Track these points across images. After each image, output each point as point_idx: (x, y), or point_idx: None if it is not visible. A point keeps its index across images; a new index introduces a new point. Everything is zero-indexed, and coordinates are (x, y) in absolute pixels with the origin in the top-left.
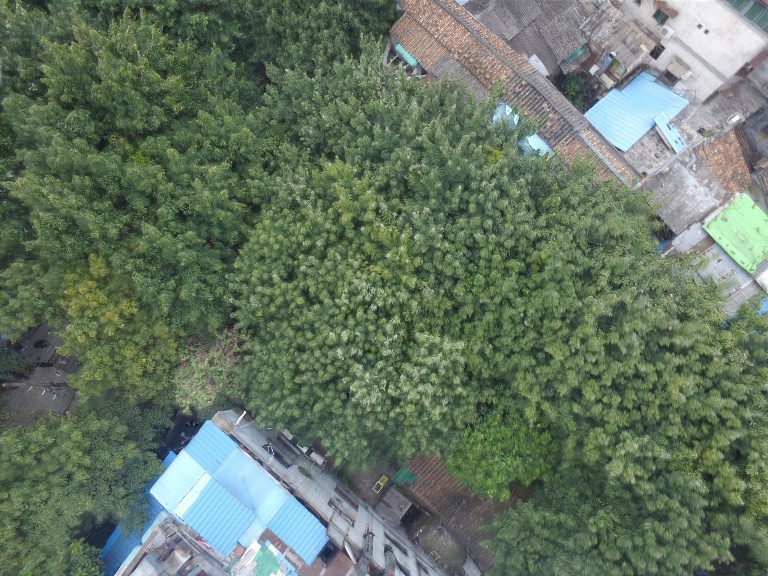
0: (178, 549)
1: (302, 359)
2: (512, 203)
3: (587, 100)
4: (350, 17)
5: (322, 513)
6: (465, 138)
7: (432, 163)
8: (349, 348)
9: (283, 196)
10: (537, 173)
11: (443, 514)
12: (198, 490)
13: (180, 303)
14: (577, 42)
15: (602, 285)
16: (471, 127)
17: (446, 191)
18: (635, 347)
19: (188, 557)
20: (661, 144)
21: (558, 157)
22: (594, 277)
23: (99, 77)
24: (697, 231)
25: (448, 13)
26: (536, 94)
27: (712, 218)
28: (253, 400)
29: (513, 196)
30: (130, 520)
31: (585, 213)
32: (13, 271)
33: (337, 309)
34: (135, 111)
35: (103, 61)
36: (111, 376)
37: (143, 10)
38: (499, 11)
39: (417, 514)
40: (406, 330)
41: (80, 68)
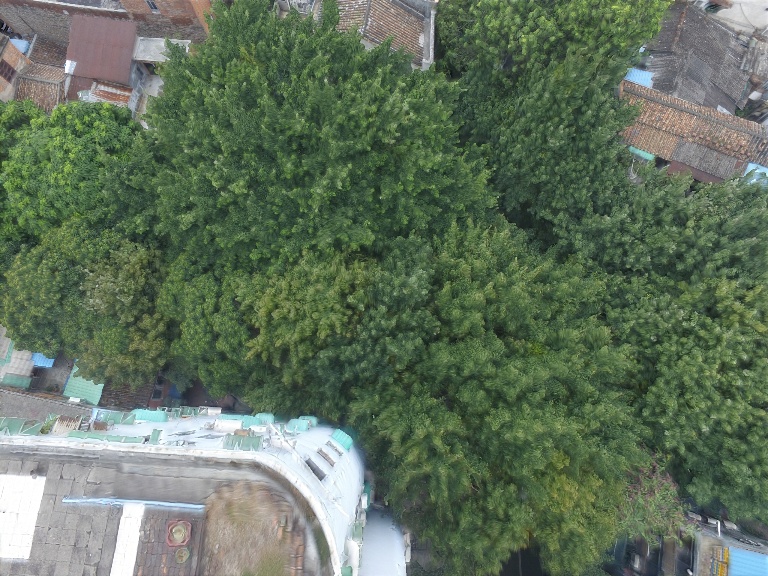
0: None
1: None
2: None
3: None
4: None
5: None
6: None
7: None
8: None
9: None
10: None
11: None
12: None
13: None
14: (743, 81)
15: None
16: None
17: None
18: None
19: None
20: None
21: None
22: None
23: None
24: None
25: (669, 107)
26: None
27: None
28: (732, 509)
29: None
30: None
31: None
32: (493, 499)
33: None
34: (521, 311)
35: None
36: None
37: (471, 219)
38: (686, 84)
39: None
40: None
41: None
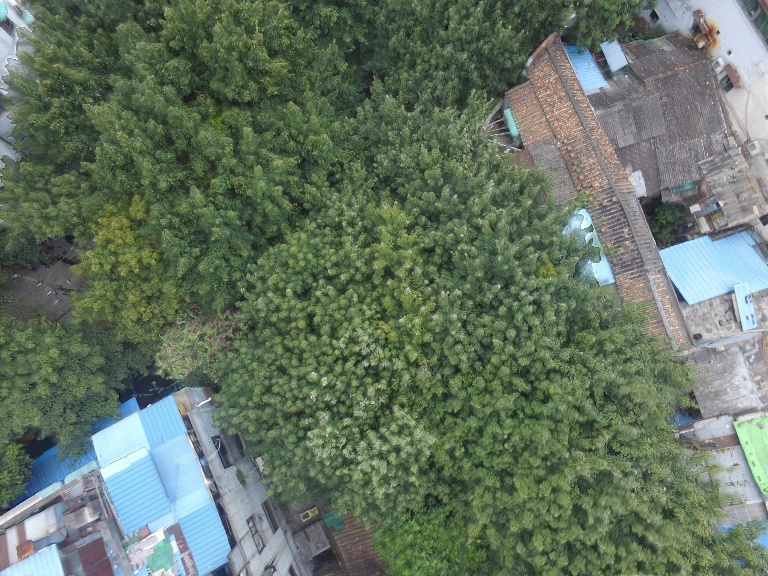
0: (89, 507)
1: (278, 381)
2: (544, 323)
3: (675, 233)
4: (471, 68)
5: (235, 530)
6: (526, 239)
7: (484, 248)
8: (325, 392)
9: (332, 214)
10: (583, 302)
11: (353, 574)
12: (131, 461)
13: (197, 270)
14: (689, 175)
15: (598, 446)
16: (538, 229)
17: (486, 280)
18: (604, 523)
19: (95, 518)
20: (731, 313)
21: (616, 286)
22: (595, 432)
23: (213, 36)
24: (726, 424)
25: (570, 99)
26: (622, 215)
27: (747, 419)
28: (221, 393)
29: (547, 318)
30: (70, 446)
31: (614, 363)
32: (64, 180)
33: (331, 349)
34: (232, 79)
35: (220, 26)
36: (108, 310)
37: None
38: (623, 115)
39: (331, 558)
40: (388, 396)
41: (199, 22)
